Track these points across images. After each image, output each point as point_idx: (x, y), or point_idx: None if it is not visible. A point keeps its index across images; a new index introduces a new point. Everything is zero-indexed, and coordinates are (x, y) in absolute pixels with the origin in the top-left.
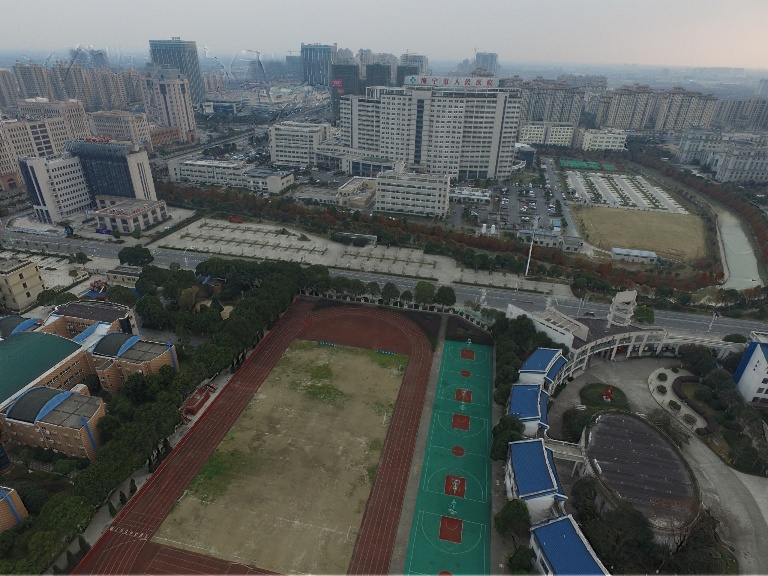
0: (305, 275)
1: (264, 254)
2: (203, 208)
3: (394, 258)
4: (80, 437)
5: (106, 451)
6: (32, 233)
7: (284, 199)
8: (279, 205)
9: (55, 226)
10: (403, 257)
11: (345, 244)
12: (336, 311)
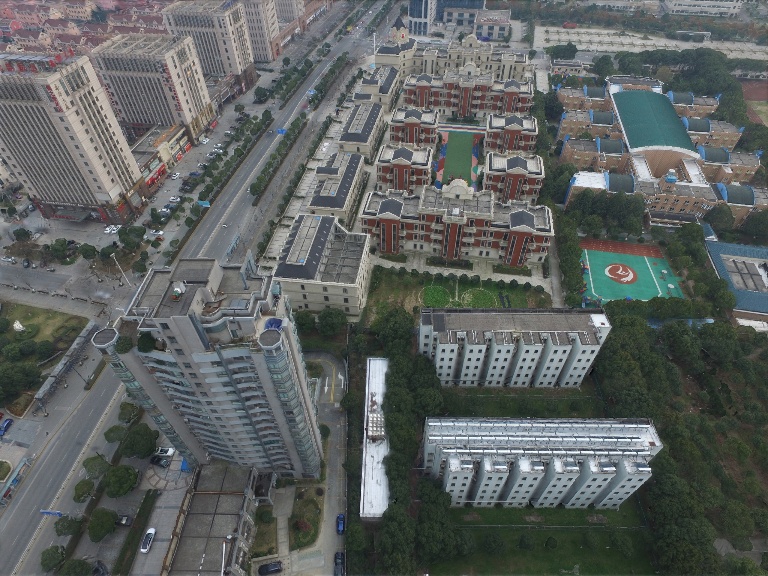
0: (723, 58)
1: (634, 50)
2: (521, 18)
3: (740, 49)
4: (738, 139)
5: (762, 144)
6: (425, 43)
7: (590, 6)
8: (586, 12)
9: (431, 37)
10: (745, 48)
11: (686, 41)
12: (750, 84)
